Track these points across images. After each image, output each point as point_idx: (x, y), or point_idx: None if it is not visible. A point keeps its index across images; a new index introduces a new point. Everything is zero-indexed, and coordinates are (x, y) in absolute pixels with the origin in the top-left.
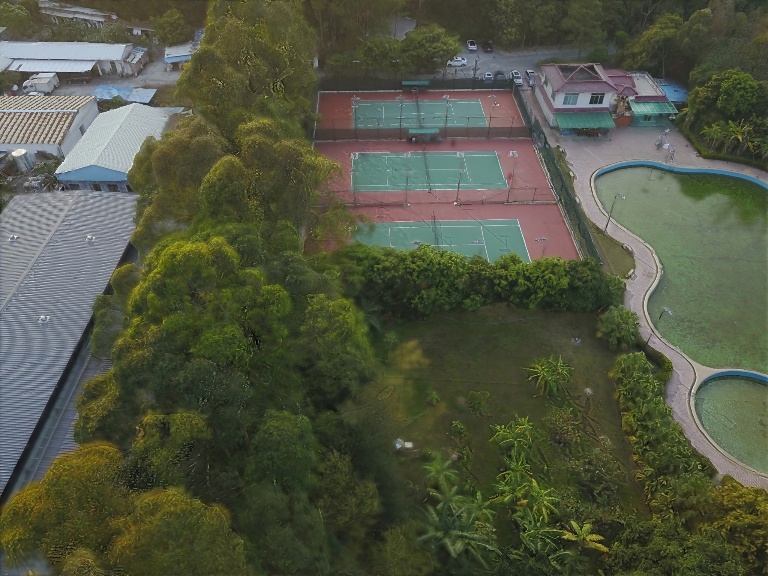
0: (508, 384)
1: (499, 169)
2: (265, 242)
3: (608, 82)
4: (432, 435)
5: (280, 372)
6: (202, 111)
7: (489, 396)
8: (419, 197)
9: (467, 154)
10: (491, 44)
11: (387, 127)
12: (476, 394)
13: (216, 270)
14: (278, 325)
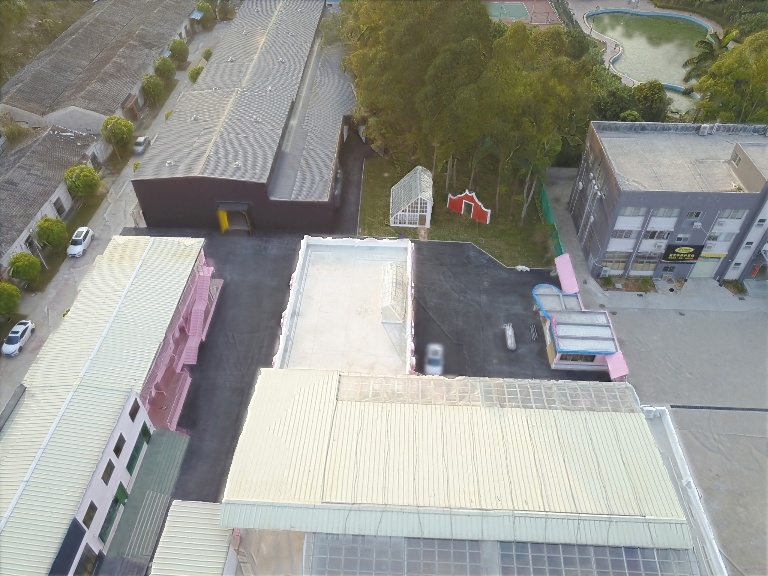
0: None
1: (525, 10)
2: None
3: None
4: None
5: None
6: None
7: None
8: None
9: (505, 3)
10: None
11: None
12: None
13: None
14: None
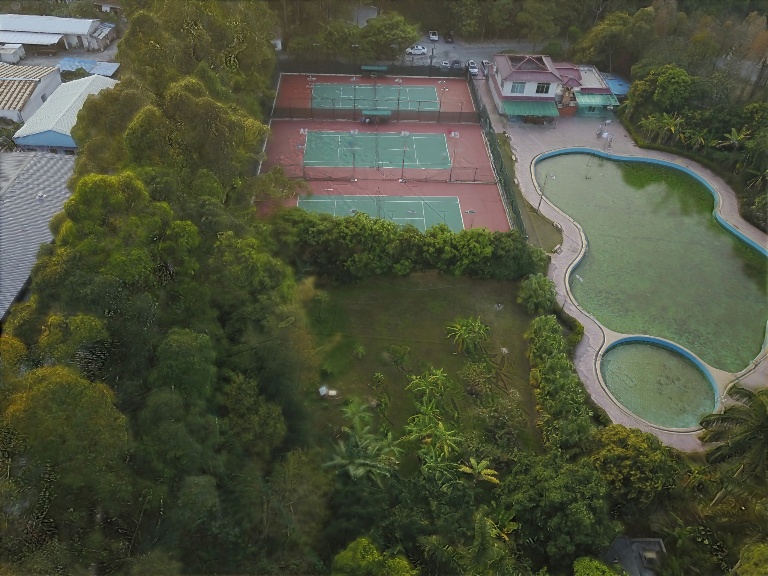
0: (431, 342)
1: (446, 151)
2: (187, 188)
3: (553, 73)
4: (355, 385)
5: (195, 305)
6: (141, 72)
7: (412, 352)
8: (367, 174)
9: (417, 136)
10: (452, 35)
11: (343, 108)
12: (397, 348)
13: (126, 199)
14: (190, 258)
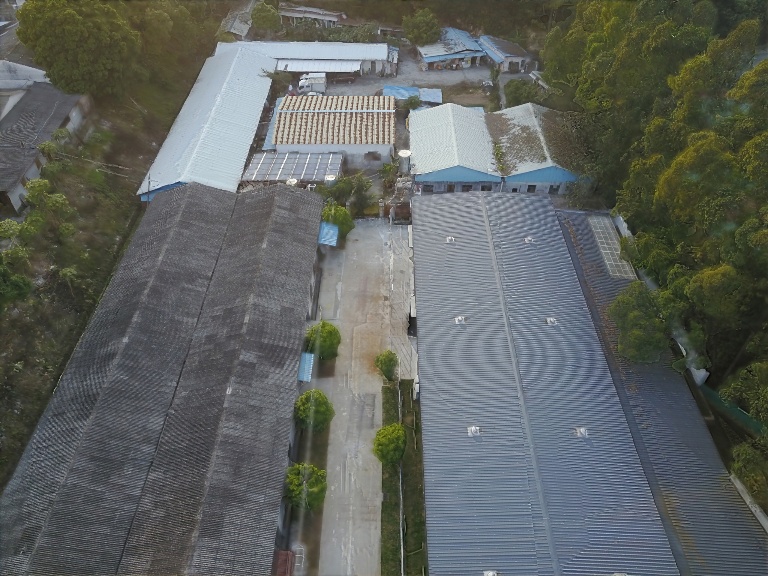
0: None
1: None
2: None
3: None
4: None
5: None
6: None
7: None
8: None
9: None
10: None
11: None
12: None
13: None
14: None
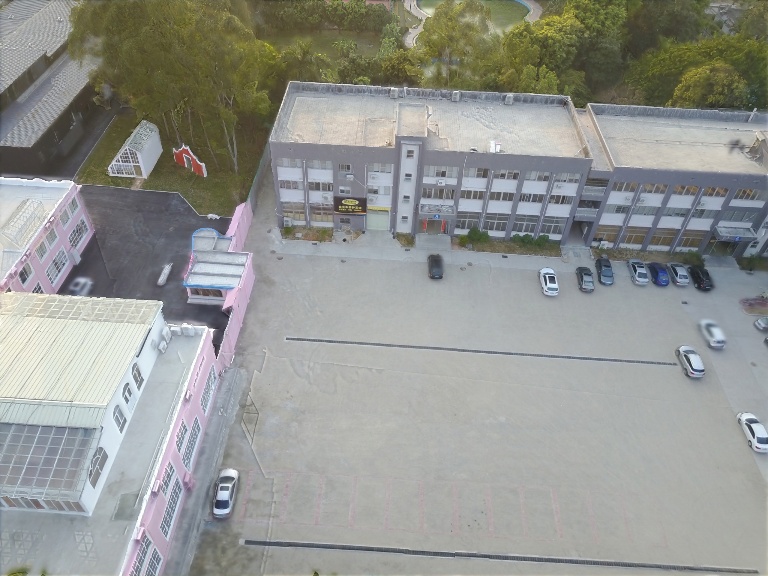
0: None
1: None
2: None
3: None
4: None
5: None
6: None
7: None
8: None
9: None
10: None
11: None
12: None
13: None
14: None
